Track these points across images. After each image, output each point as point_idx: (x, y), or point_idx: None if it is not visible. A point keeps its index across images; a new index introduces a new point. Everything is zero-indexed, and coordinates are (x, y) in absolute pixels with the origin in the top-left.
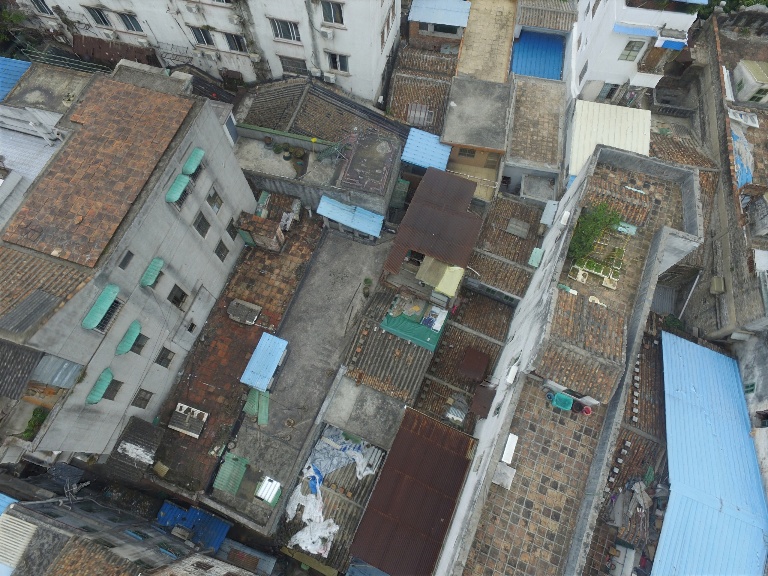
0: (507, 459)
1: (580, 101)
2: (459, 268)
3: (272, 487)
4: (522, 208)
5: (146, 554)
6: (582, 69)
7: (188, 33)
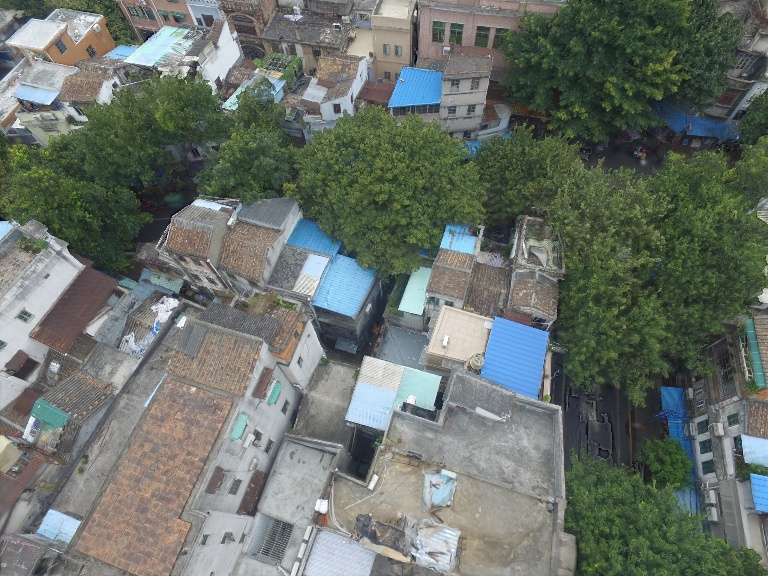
0: None
1: None
2: None
3: (182, 324)
4: None
5: (242, 285)
6: None
7: None
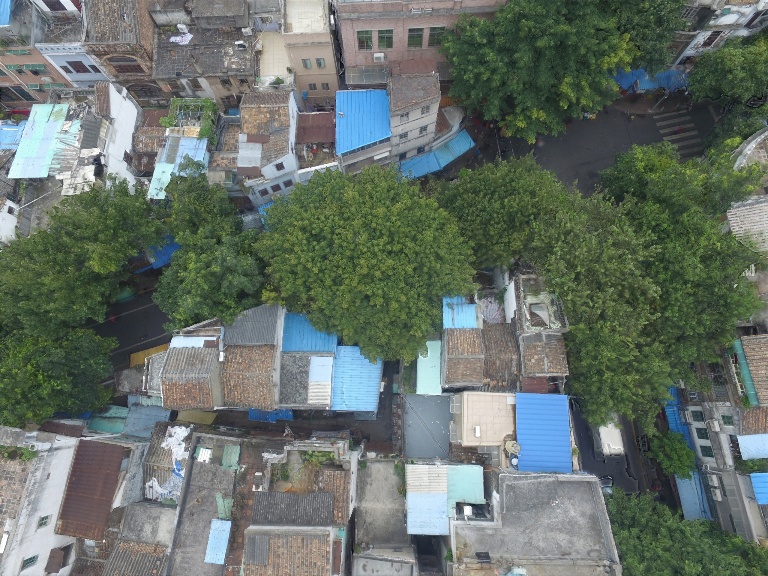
0: (5, 537)
1: None
2: None
3: (203, 457)
4: None
5: None
6: None
7: None
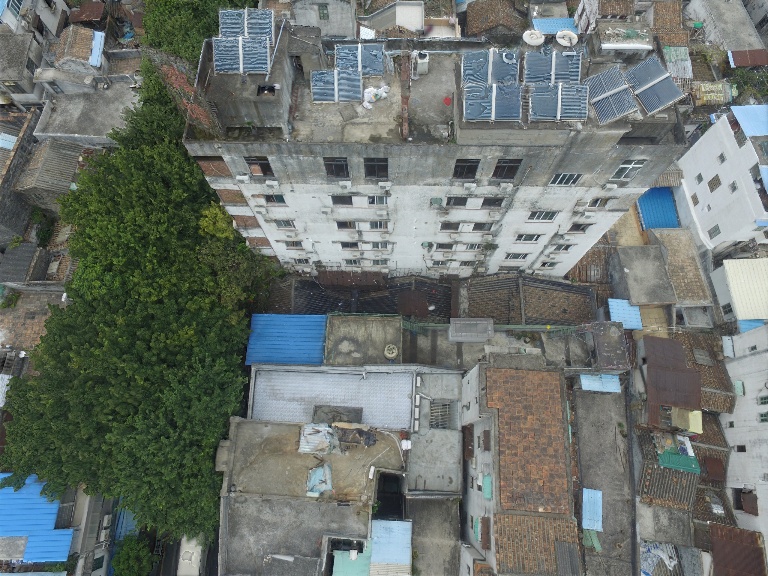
0: None
1: (726, 261)
2: (698, 412)
3: None
4: (691, 335)
5: None
6: (711, 228)
7: (429, 263)
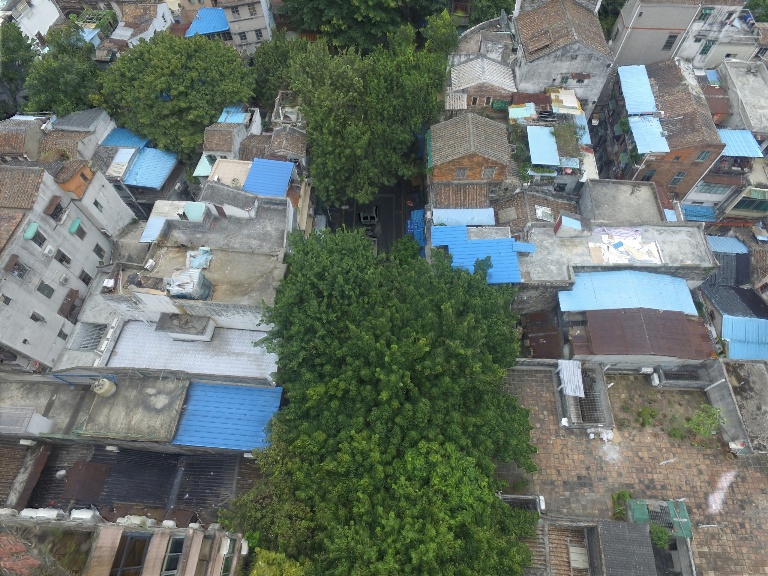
0: None
1: None
2: None
3: None
4: None
5: None
6: None
7: None
